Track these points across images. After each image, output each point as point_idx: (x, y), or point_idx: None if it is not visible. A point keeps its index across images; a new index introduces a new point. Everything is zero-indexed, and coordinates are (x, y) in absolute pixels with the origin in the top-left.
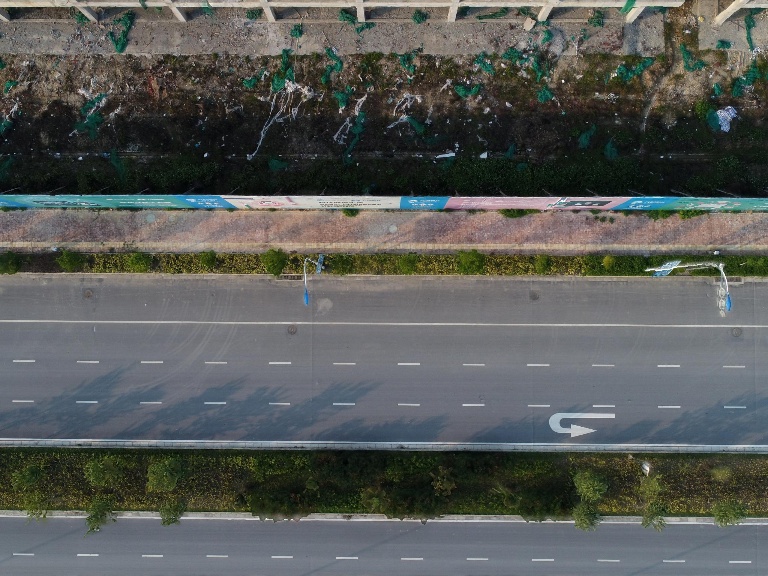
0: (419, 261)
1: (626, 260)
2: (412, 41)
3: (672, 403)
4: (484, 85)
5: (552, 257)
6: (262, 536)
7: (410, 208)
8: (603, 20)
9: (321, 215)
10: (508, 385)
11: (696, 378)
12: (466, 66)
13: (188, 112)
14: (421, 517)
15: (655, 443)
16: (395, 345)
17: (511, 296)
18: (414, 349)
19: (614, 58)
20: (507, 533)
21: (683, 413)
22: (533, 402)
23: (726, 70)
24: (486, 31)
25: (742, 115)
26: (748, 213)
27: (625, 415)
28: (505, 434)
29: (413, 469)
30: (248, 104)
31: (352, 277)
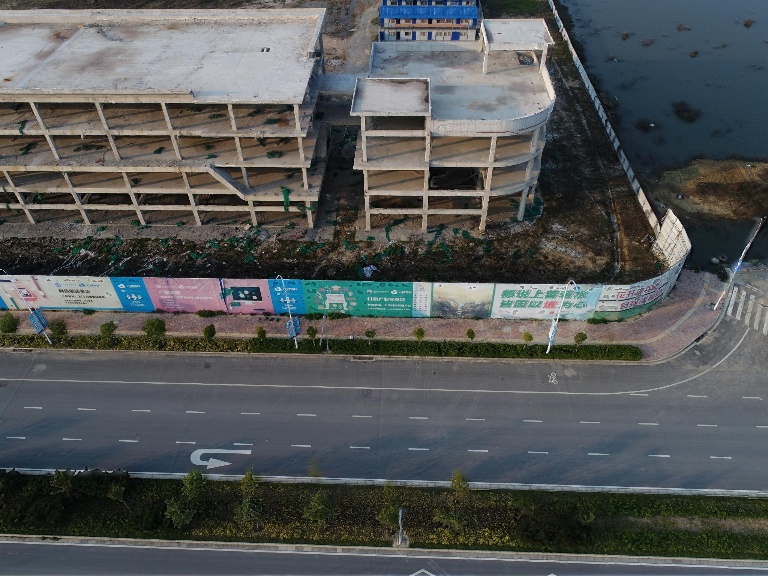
0: (125, 340)
1: (281, 340)
2: (172, 234)
3: (304, 443)
4: (211, 254)
5: (226, 338)
6: None
7: (132, 310)
8: (294, 226)
9: (67, 314)
10: (165, 426)
11: (328, 424)
12: (202, 244)
13: (8, 262)
14: (30, 524)
15: (283, 475)
16: (82, 396)
17: (189, 365)
18: (96, 399)
19: (298, 242)
20: (116, 558)
21: (313, 451)
22: (182, 439)
23: (372, 250)
24: (220, 230)
25: (380, 270)
26: (379, 318)
27: (261, 452)
28: (148, 465)
29: (48, 488)
30: (51, 259)
31: (71, 351)
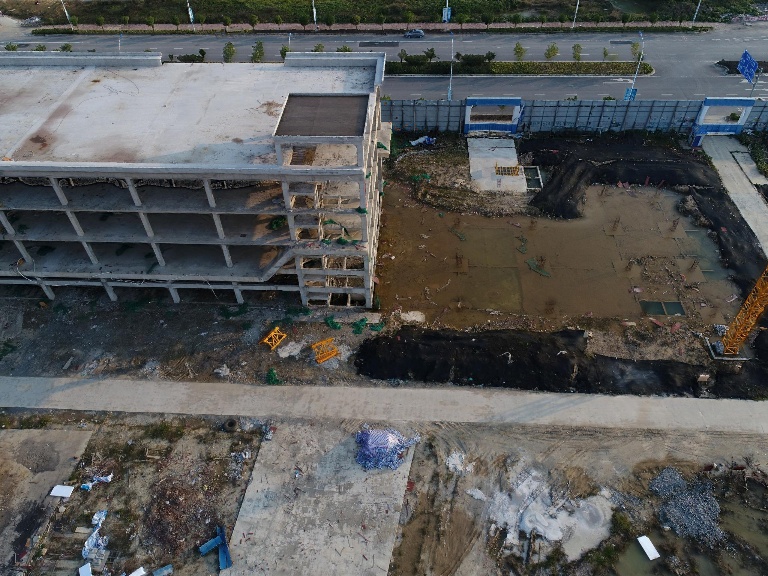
0: None
1: None
2: None
3: None
4: None
5: None
6: (205, 59)
7: None
8: None
9: None
10: None
11: None
12: None
13: None
14: None
15: None
16: None
17: None
18: None
19: None
20: None
21: None
22: None
23: None
24: (6, 181)
25: None
26: None
27: None
28: None
29: None
30: None
31: None
